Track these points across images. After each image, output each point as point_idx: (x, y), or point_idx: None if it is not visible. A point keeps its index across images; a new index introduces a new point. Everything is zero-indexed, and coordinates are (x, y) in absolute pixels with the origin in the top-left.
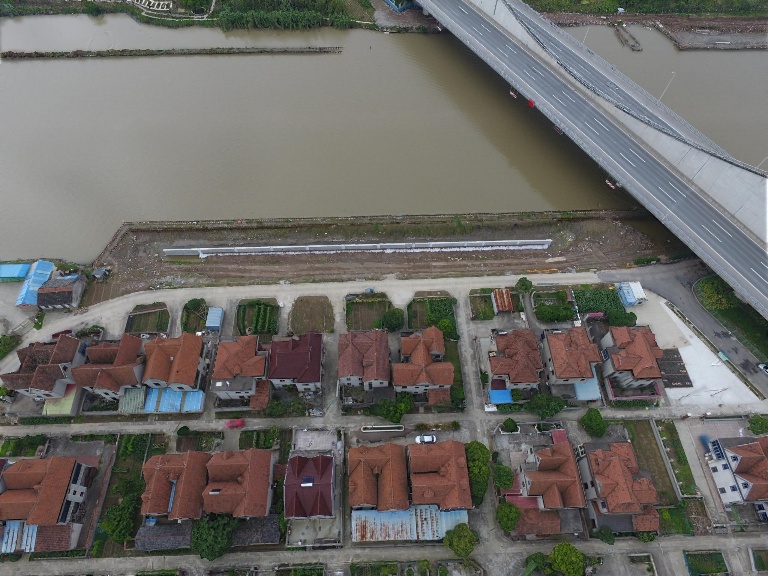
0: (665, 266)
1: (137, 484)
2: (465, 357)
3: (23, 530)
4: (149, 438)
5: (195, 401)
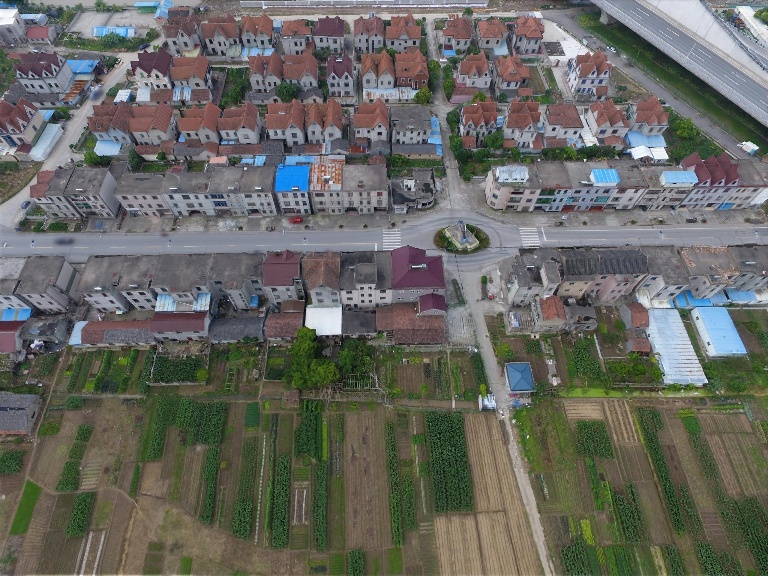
0: (559, 10)
1: (242, 80)
2: (430, 43)
3: (183, 91)
4: (245, 69)
5: (270, 52)
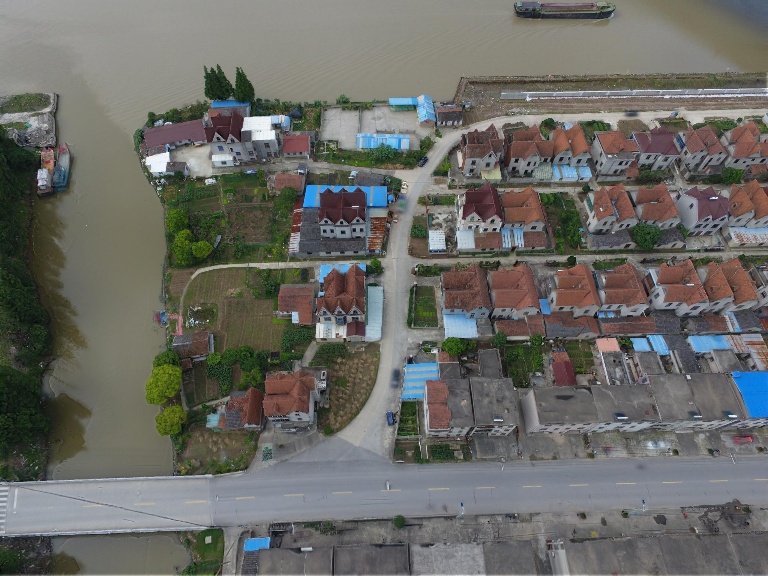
0: None
1: (572, 215)
2: None
3: (514, 234)
4: (560, 195)
5: (587, 172)
